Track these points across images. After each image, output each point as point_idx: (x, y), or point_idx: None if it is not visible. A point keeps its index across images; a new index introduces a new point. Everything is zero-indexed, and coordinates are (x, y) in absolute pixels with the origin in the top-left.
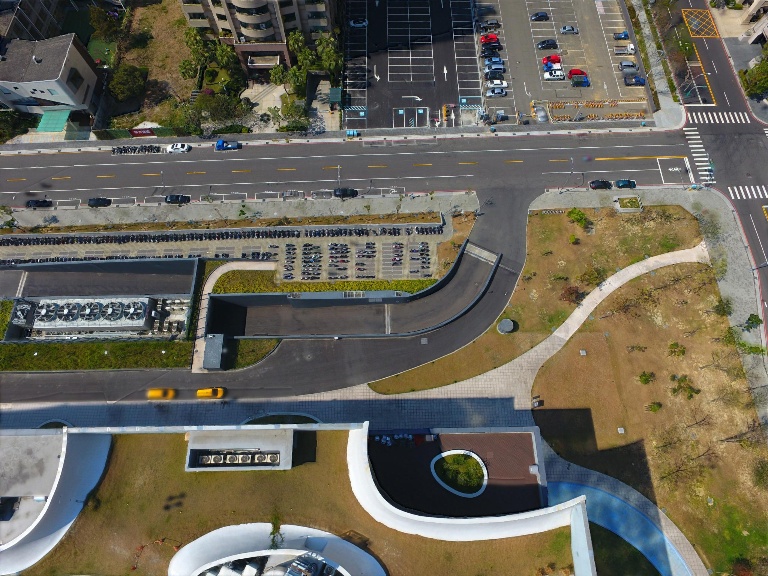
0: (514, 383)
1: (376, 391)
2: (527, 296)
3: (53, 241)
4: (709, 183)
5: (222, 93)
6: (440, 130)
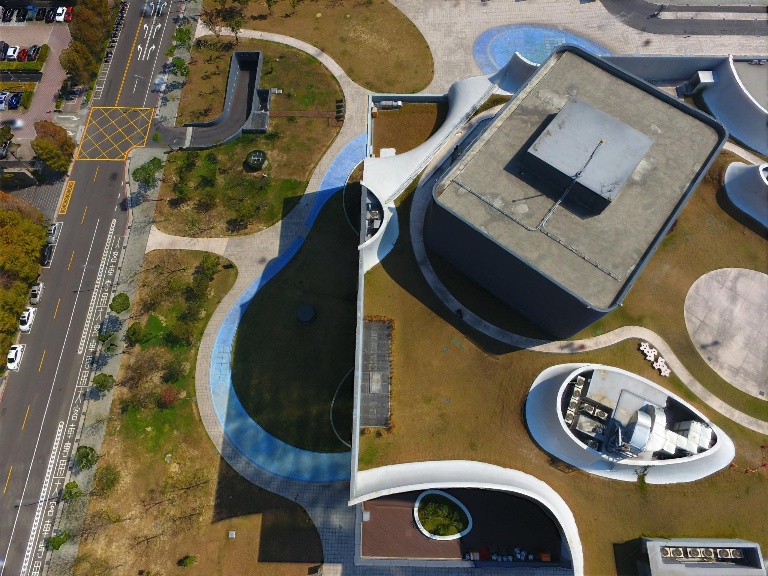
0: None
1: None
2: None
3: None
4: None
5: None
6: None
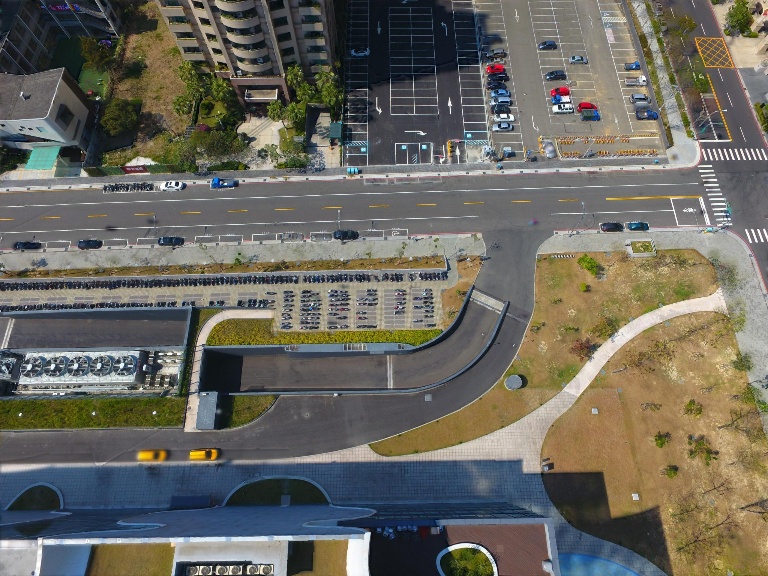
0: (522, 444)
1: (378, 452)
2: (536, 348)
3: (41, 286)
4: (725, 225)
5: (218, 127)
6: (444, 167)
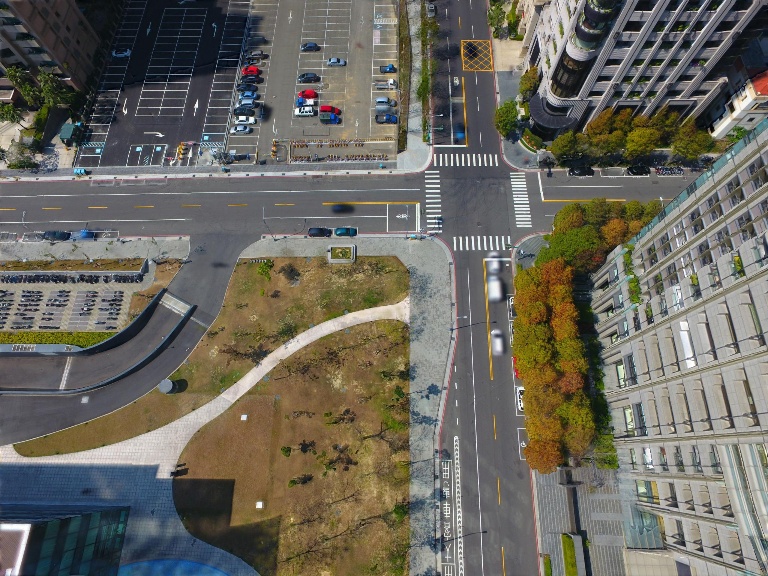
0: (163, 449)
1: (19, 453)
2: (207, 353)
3: None
4: (435, 232)
5: None
6: (173, 169)
